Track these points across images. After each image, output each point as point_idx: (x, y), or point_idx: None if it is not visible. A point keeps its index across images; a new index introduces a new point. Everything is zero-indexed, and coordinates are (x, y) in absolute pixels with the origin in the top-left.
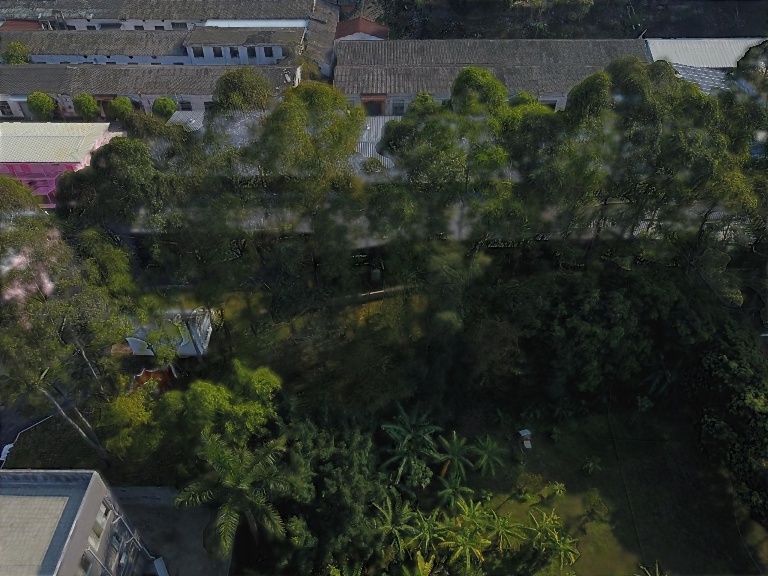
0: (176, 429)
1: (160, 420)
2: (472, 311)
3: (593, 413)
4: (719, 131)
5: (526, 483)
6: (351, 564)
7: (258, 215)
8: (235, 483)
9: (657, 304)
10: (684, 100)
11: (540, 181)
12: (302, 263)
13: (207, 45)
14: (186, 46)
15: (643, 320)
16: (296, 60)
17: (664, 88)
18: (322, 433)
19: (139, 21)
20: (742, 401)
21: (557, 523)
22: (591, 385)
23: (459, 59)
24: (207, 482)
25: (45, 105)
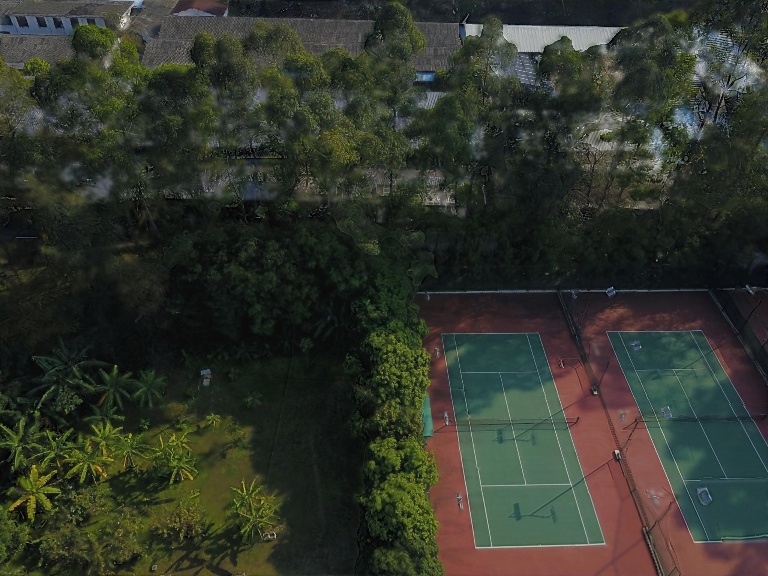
0: None
1: None
2: (144, 256)
3: (279, 356)
4: (328, 90)
5: (171, 411)
6: None
7: None
8: None
9: (314, 253)
10: (288, 60)
11: (156, 131)
12: None
13: (29, 15)
14: (9, 15)
15: (306, 268)
16: (116, 32)
17: (285, 50)
18: None
19: None
20: (368, 339)
21: (179, 444)
22: (265, 328)
23: None
24: None
25: None
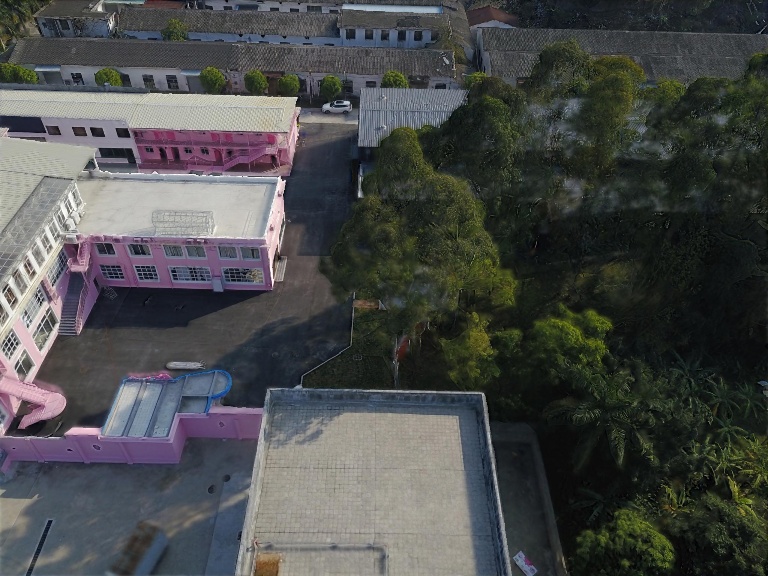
0: (501, 366)
1: (494, 356)
2: None
3: None
4: None
5: None
6: (676, 485)
7: (561, 175)
8: (631, 401)
9: None
10: None
11: None
12: (612, 219)
13: (361, 27)
14: (340, 28)
15: None
16: (447, 44)
17: None
18: (647, 369)
19: (276, 3)
20: None
21: None
22: None
23: (599, 48)
24: (593, 402)
25: (218, 80)
